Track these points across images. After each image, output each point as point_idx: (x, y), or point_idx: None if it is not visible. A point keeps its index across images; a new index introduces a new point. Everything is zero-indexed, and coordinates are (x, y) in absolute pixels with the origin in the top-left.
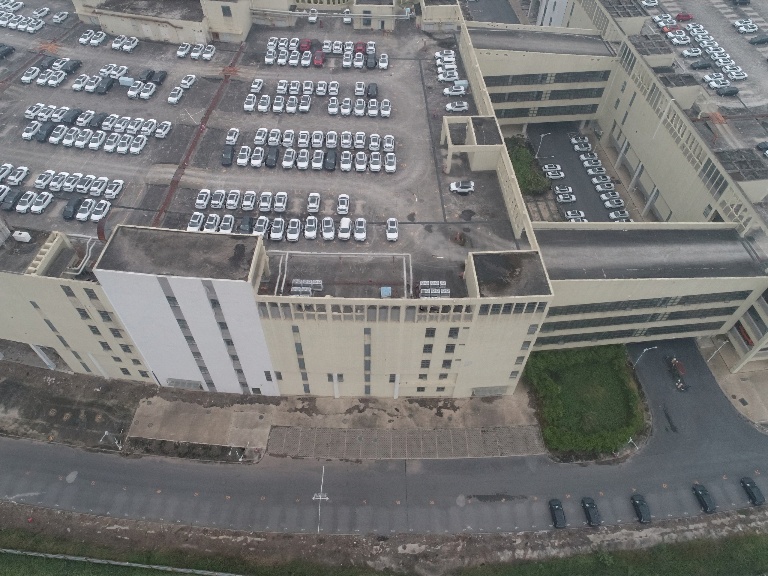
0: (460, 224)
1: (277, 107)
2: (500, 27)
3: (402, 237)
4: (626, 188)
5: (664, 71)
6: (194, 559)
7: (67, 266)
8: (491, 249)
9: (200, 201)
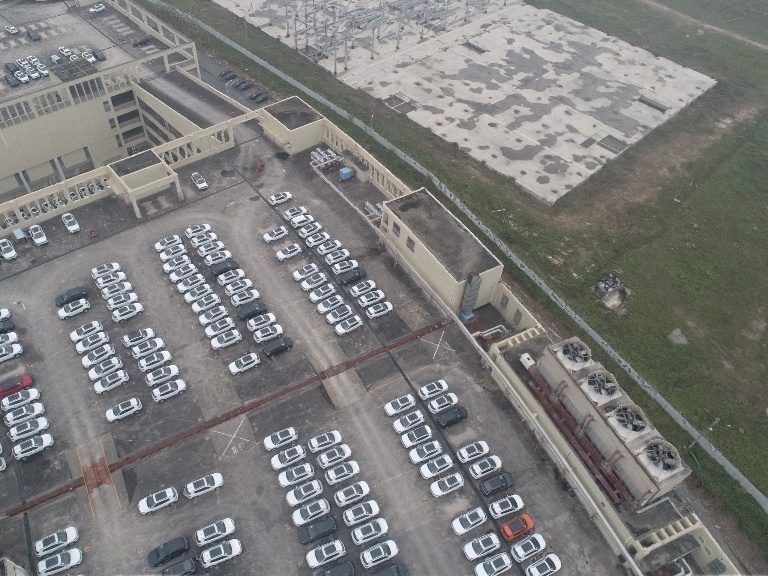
0: (242, 173)
1: (164, 355)
2: None
3: None
4: None
5: None
6: (527, 284)
7: (505, 337)
8: (256, 153)
9: (357, 318)
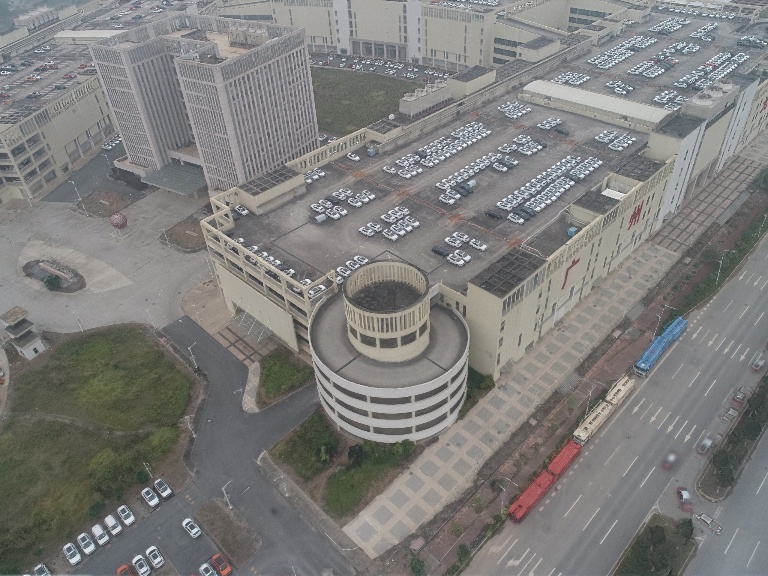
0: None
1: None
2: (257, 6)
3: None
4: None
5: None
6: None
7: None
8: None
9: None
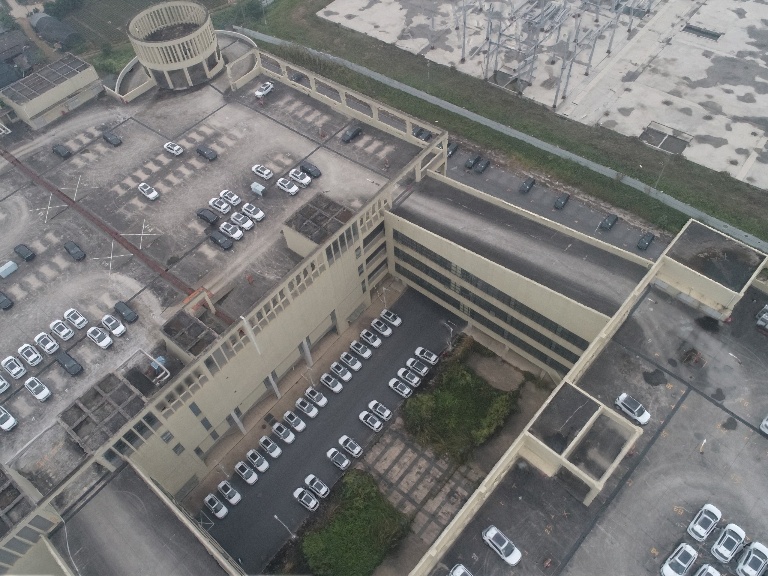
0: (675, 374)
1: None
2: None
3: (763, 408)
4: (277, 402)
5: (142, 379)
6: None
7: None
8: (666, 326)
9: None
